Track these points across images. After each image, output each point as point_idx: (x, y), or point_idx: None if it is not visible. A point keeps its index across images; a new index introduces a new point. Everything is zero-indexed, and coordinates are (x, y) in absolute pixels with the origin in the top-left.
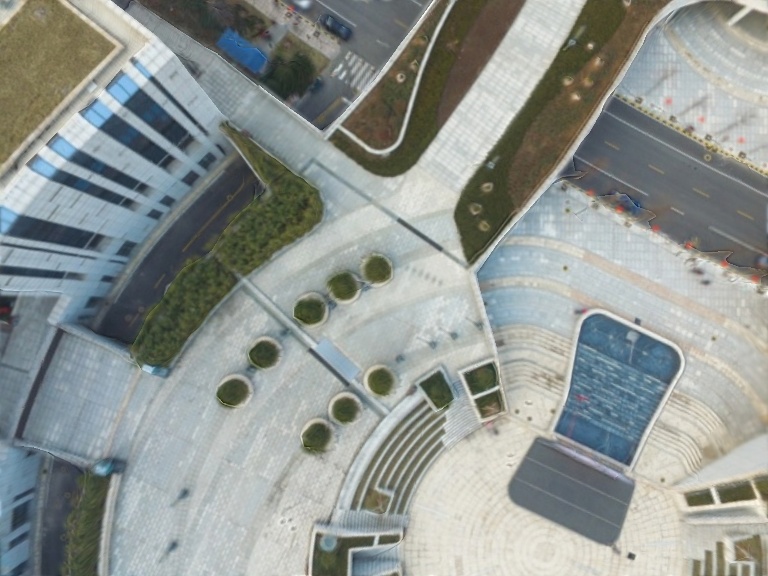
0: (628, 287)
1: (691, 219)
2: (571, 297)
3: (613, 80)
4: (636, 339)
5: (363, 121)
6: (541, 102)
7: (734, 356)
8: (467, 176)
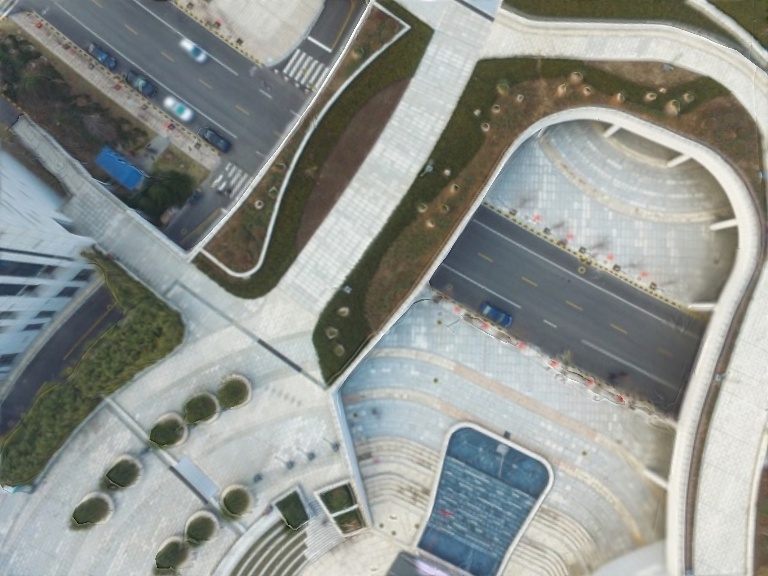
0: (498, 400)
1: (564, 332)
2: (441, 409)
3: (470, 205)
4: (506, 452)
5: (225, 244)
6: (397, 228)
7: (605, 471)
8: (326, 299)
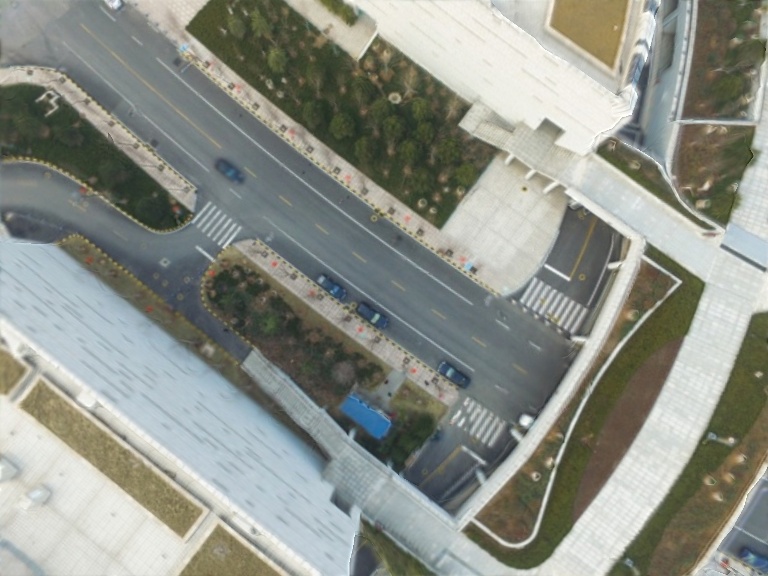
0: None
1: None
2: None
3: (755, 474)
4: None
5: (496, 513)
6: (681, 499)
7: None
8: (603, 570)
